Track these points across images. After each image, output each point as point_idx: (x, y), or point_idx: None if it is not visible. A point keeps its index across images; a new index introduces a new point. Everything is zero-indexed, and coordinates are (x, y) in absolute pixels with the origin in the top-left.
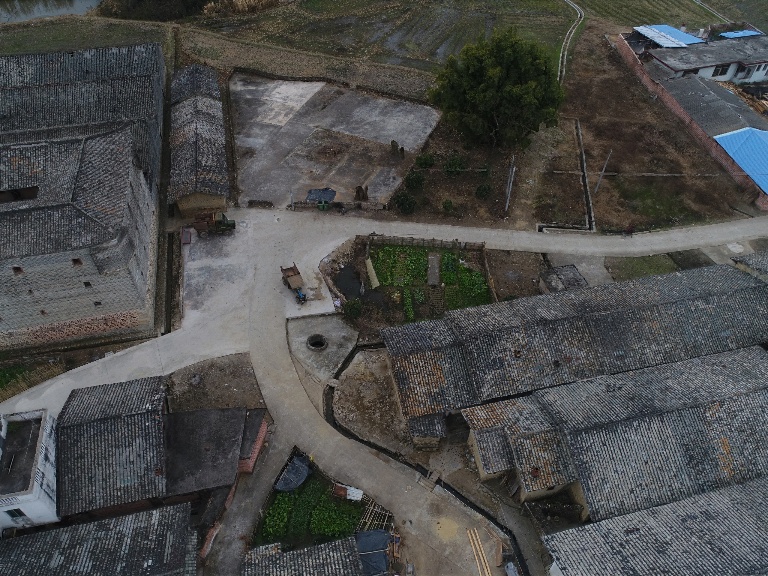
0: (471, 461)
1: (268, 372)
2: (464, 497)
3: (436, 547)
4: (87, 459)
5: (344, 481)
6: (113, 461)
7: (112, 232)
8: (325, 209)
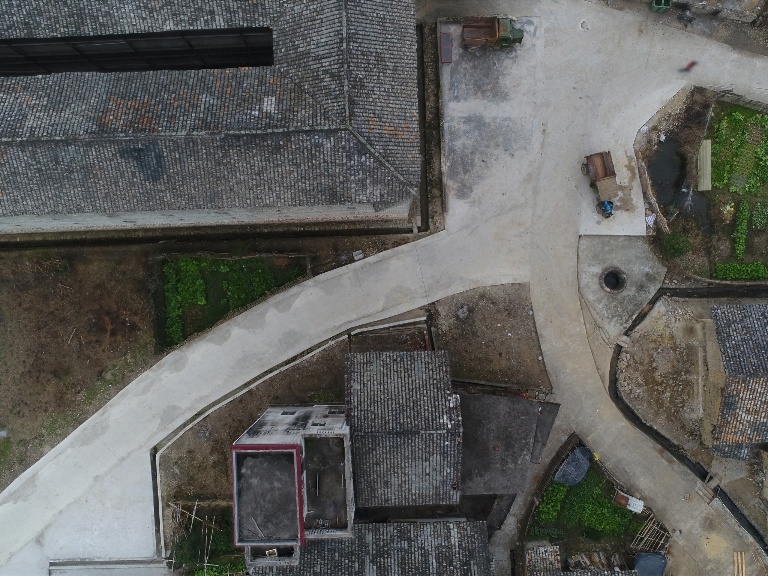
0: (759, 475)
1: (551, 319)
2: (737, 508)
3: (699, 561)
4: (383, 466)
5: (621, 476)
6: (409, 471)
7: (413, 193)
8: (660, 11)
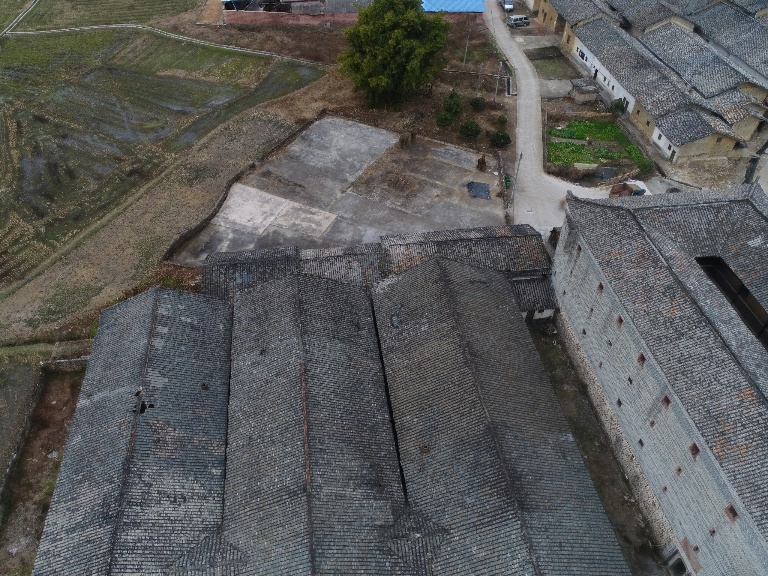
0: None
1: None
2: None
3: None
4: None
5: None
6: None
7: None
8: None
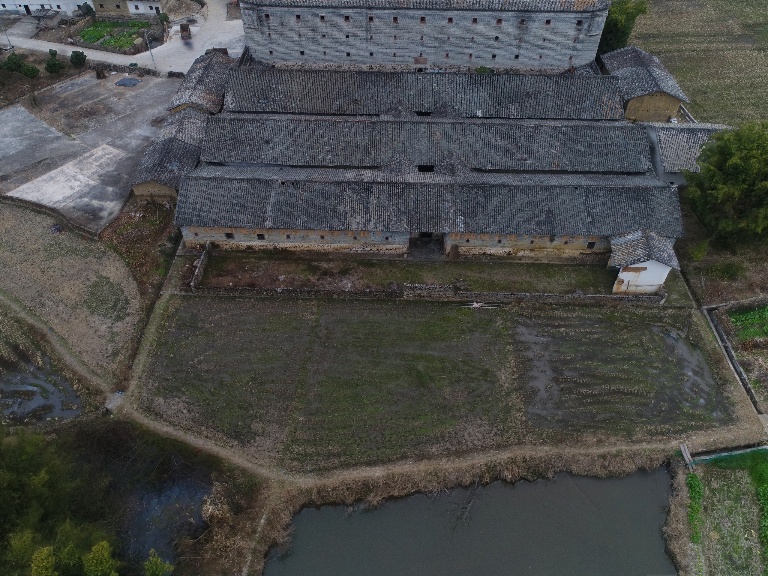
0: None
1: None
2: None
3: None
4: None
5: None
6: None
7: None
8: None
